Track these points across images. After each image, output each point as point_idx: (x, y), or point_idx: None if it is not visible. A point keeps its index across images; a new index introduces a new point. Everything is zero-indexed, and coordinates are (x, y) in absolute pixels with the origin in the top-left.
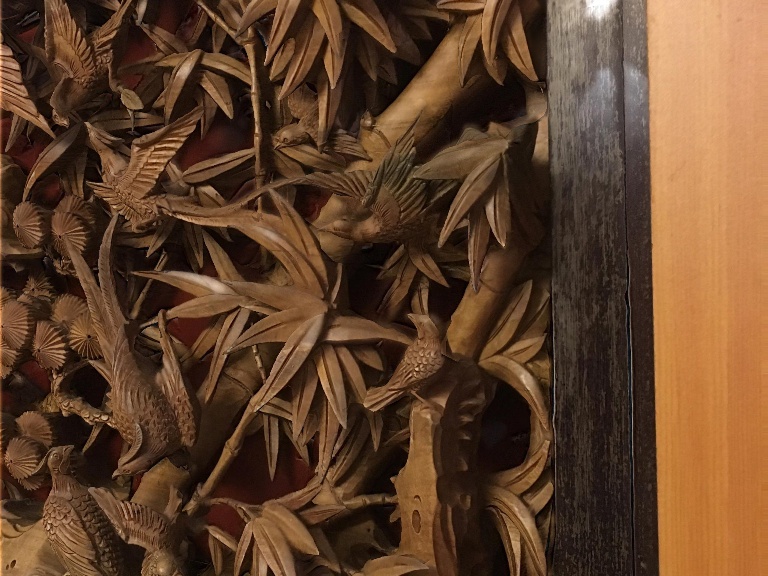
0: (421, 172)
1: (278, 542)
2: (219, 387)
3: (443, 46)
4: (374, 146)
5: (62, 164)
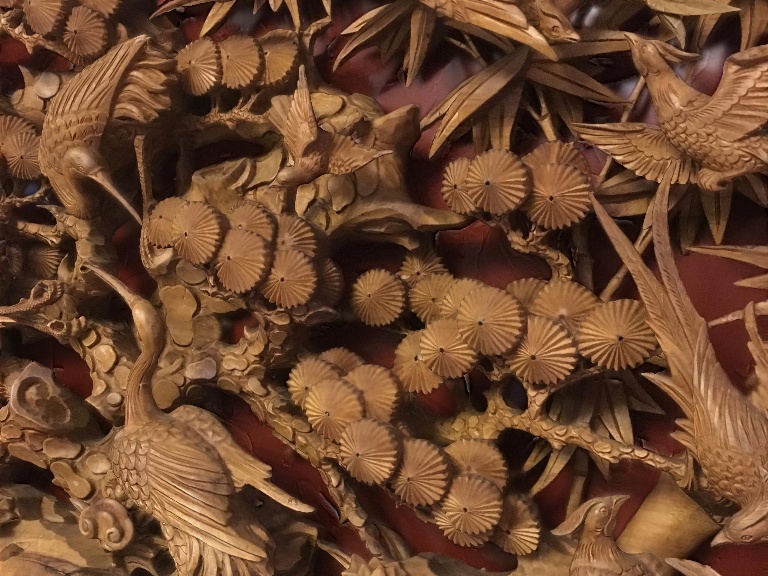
0: None
1: None
2: None
3: None
4: None
5: (492, 103)
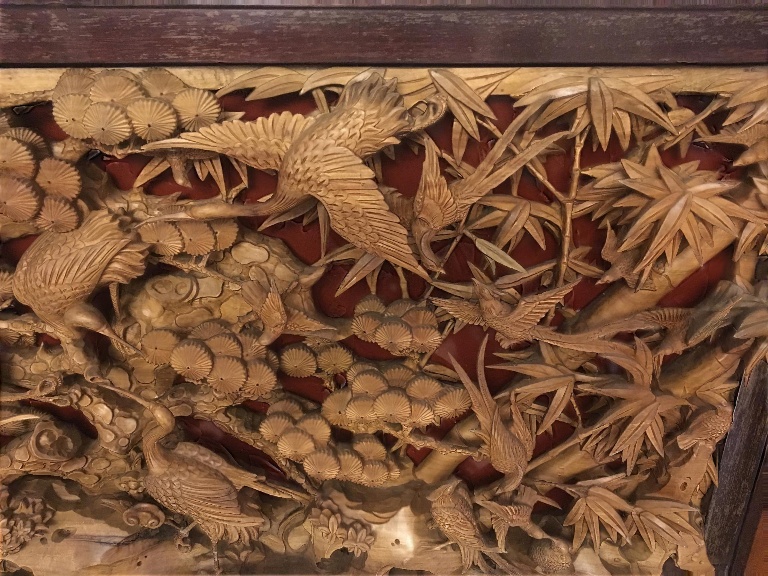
0: (742, 335)
1: (610, 509)
2: None
3: (720, 229)
4: (661, 284)
5: None
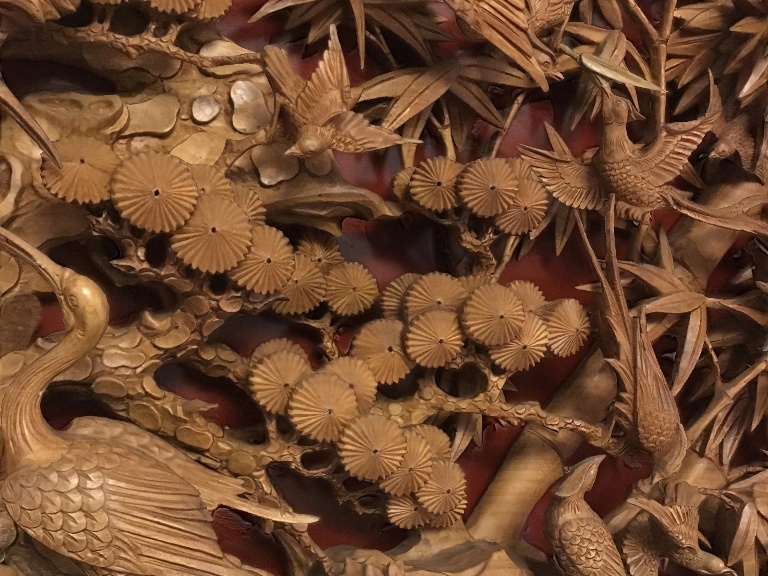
0: None
1: None
2: (609, 382)
3: None
4: None
5: None
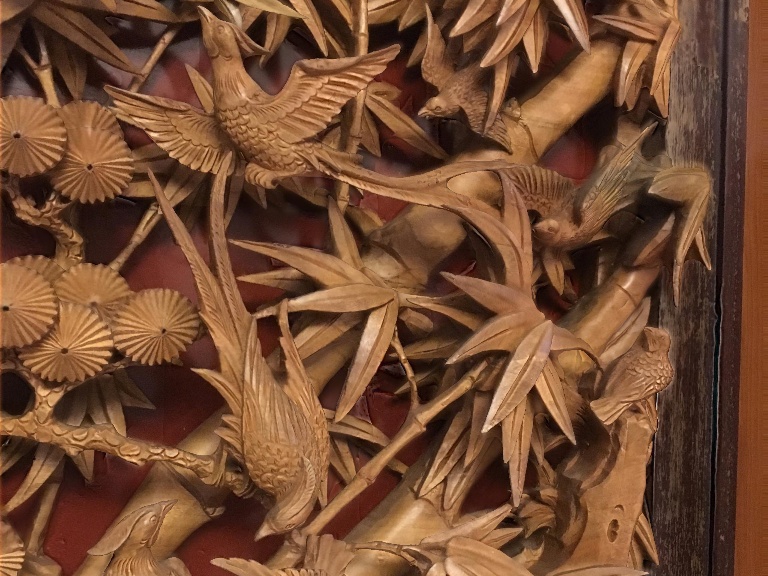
0: (660, 189)
1: None
2: None
3: (590, 58)
4: (519, 139)
5: None
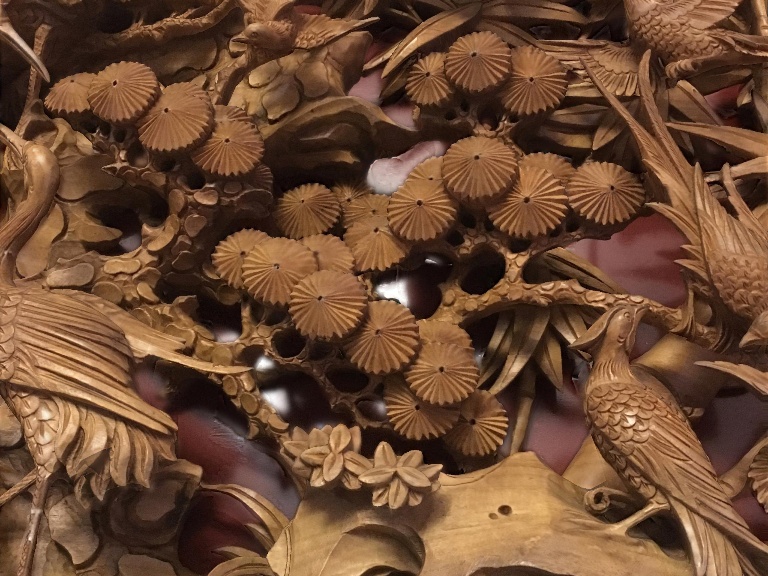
0: None
1: None
2: None
3: None
4: None
5: (444, 43)
